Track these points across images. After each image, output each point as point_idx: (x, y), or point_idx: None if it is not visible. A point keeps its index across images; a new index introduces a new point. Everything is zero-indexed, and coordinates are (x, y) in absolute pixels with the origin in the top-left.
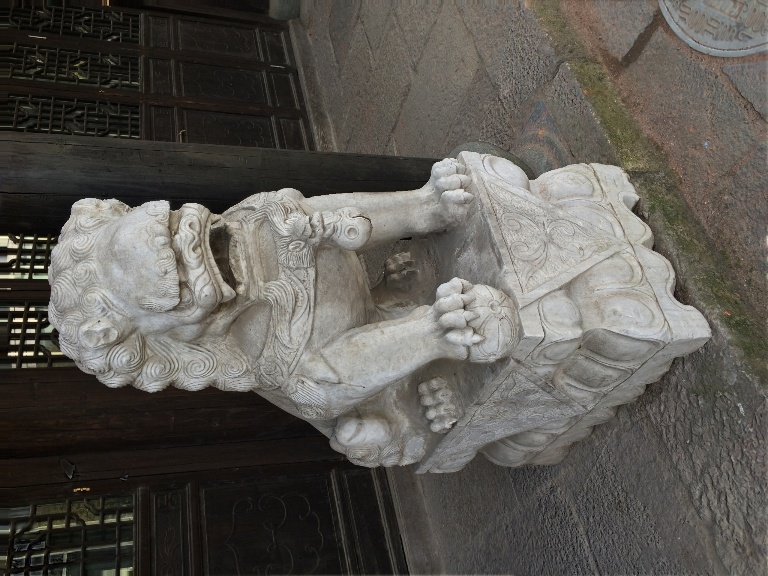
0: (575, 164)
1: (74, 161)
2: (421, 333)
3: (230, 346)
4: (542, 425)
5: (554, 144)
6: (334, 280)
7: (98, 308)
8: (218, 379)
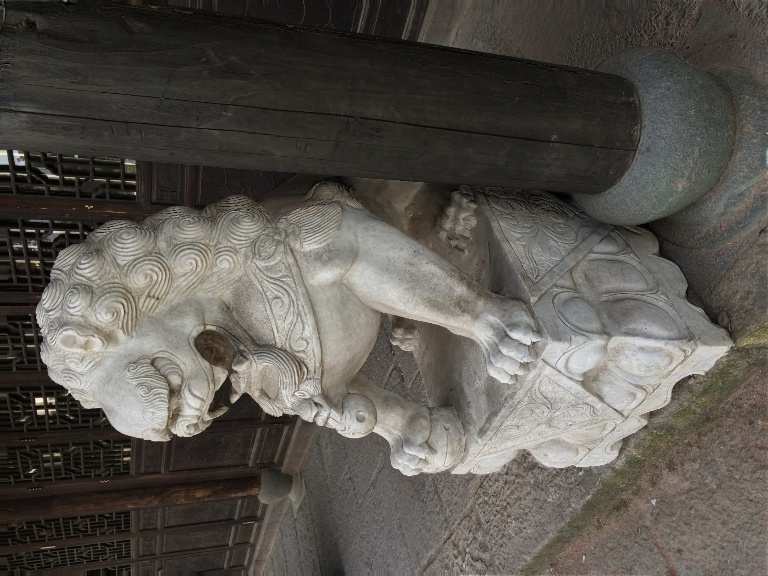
0: (678, 349)
1: (36, 138)
2: None
3: None
4: None
5: None
6: None
7: None
8: None
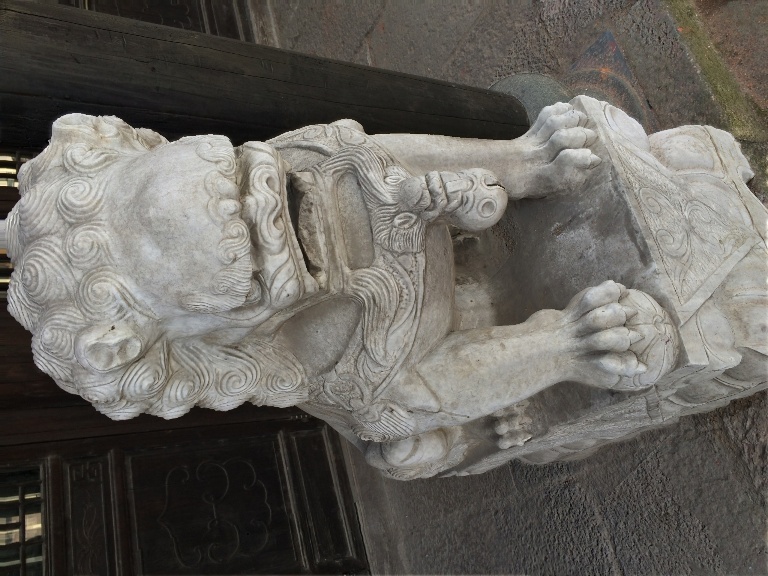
0: (692, 125)
1: (21, 39)
2: (555, 351)
3: (279, 349)
4: (607, 434)
5: (624, 89)
6: (441, 269)
7: (112, 307)
8: (258, 394)
